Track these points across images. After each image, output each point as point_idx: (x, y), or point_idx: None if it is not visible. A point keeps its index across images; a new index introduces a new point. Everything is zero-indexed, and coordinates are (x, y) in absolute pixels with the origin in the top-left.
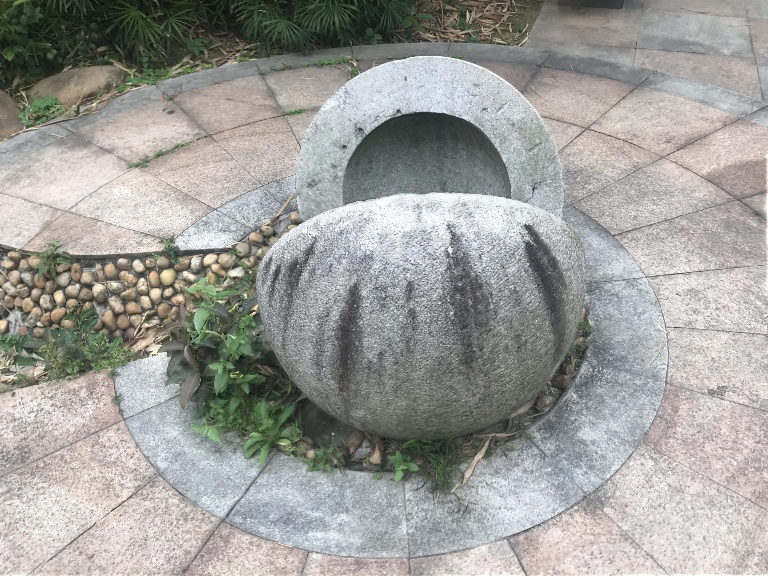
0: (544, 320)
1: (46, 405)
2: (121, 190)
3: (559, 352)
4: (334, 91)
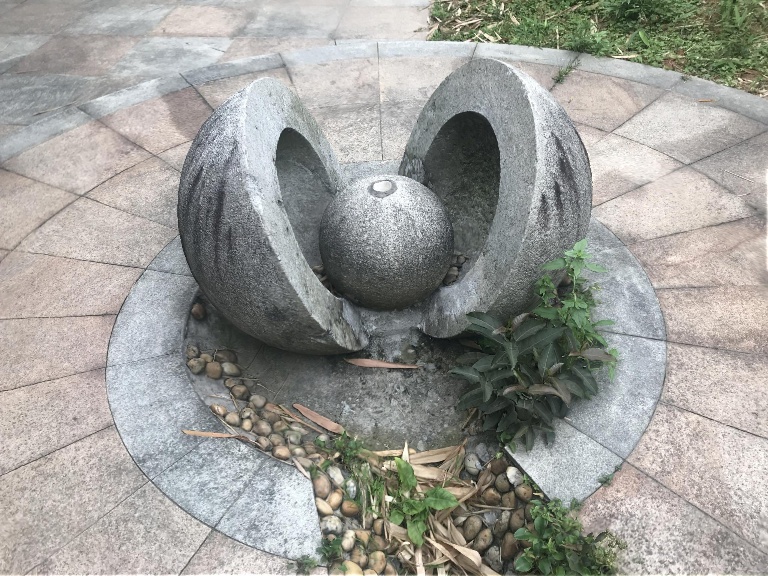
0: None
1: (654, 560)
2: None
3: None
4: None
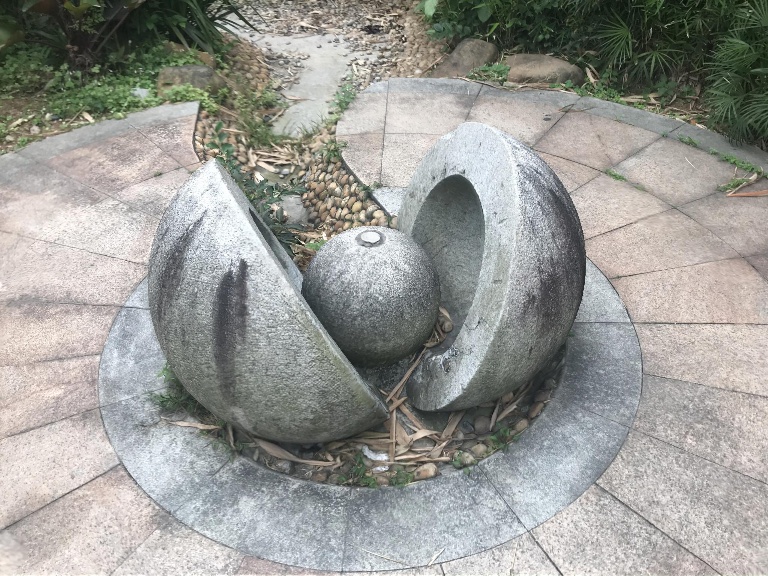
0: (207, 342)
1: None
2: (423, 142)
3: (230, 394)
4: (683, 184)
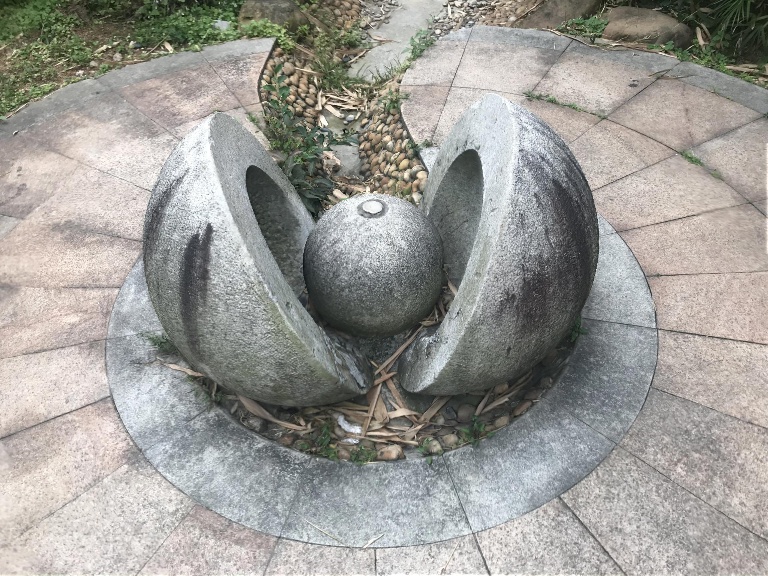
0: (175, 299)
1: None
2: None
3: (197, 351)
4: None
